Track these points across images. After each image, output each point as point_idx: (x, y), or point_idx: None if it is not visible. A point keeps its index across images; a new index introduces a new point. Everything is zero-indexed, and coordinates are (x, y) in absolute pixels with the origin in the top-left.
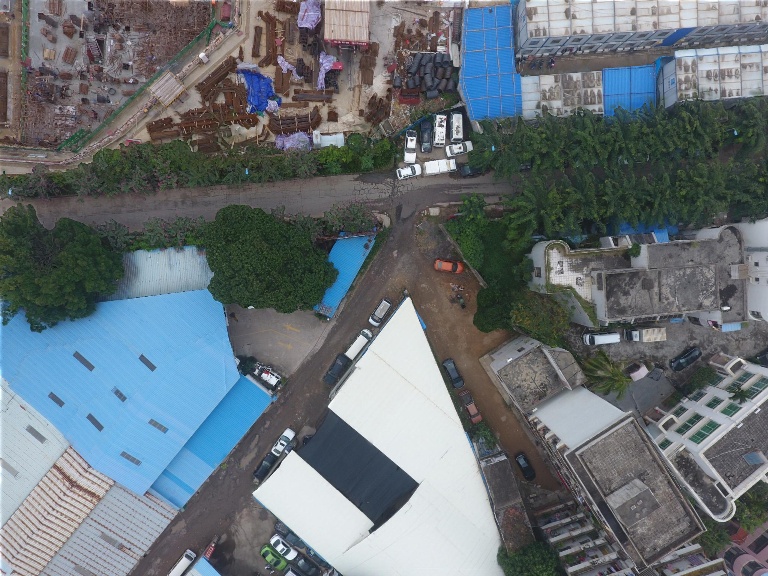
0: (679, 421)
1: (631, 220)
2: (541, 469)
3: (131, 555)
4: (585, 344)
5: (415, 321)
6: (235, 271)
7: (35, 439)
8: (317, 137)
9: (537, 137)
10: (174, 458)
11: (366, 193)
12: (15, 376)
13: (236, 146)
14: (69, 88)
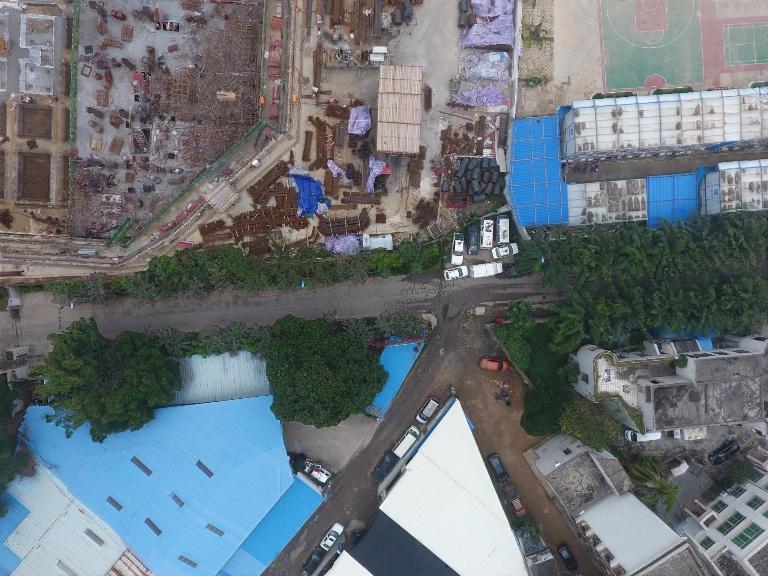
0: (720, 518)
1: (677, 330)
2: (583, 559)
3: None
4: (627, 439)
5: (464, 423)
6: (299, 395)
7: (93, 542)
8: (367, 241)
9: (587, 252)
10: (229, 559)
11: (413, 293)
12: (74, 481)
13: (287, 248)
14: (115, 177)
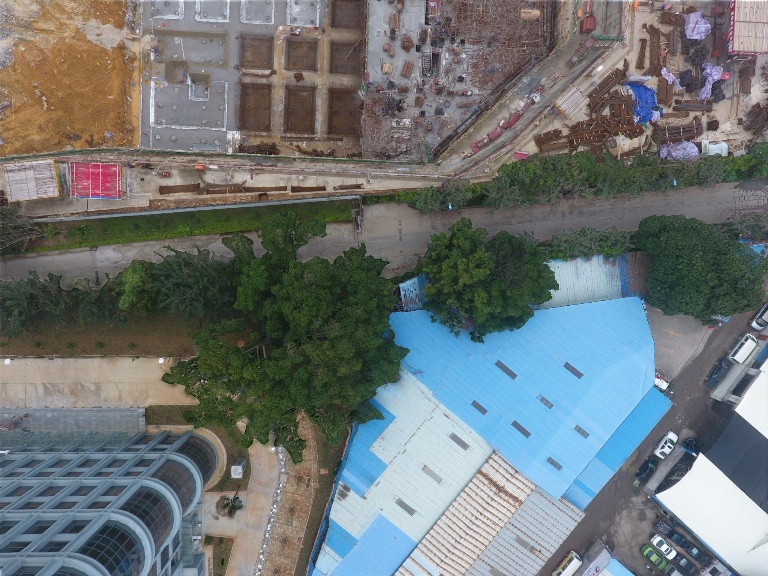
0: None
1: None
2: None
3: (540, 557)
4: None
5: None
6: (719, 281)
7: (458, 446)
8: (706, 146)
9: None
10: None
11: (746, 200)
12: (438, 385)
13: (621, 156)
14: (405, 101)
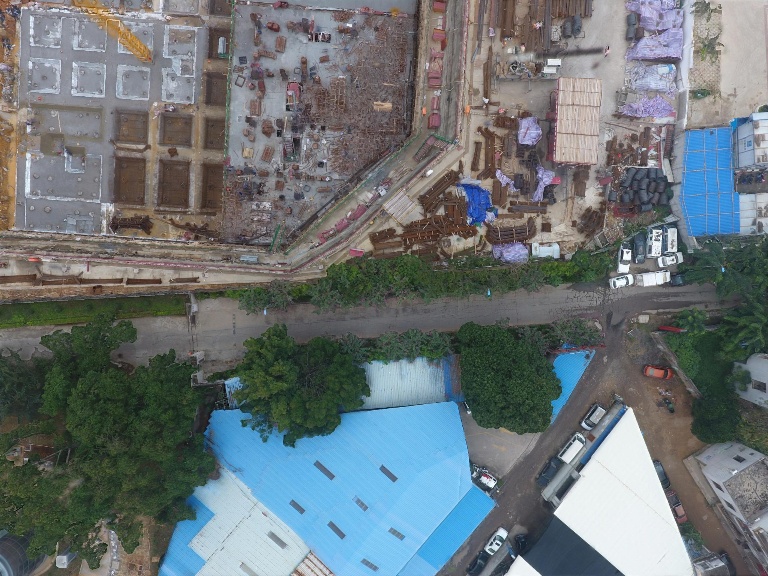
0: None
1: None
2: (740, 566)
3: None
4: None
5: (636, 430)
6: (507, 402)
7: (276, 545)
8: (536, 249)
9: None
10: (407, 563)
11: (578, 301)
12: (257, 484)
13: (455, 256)
14: (266, 185)
